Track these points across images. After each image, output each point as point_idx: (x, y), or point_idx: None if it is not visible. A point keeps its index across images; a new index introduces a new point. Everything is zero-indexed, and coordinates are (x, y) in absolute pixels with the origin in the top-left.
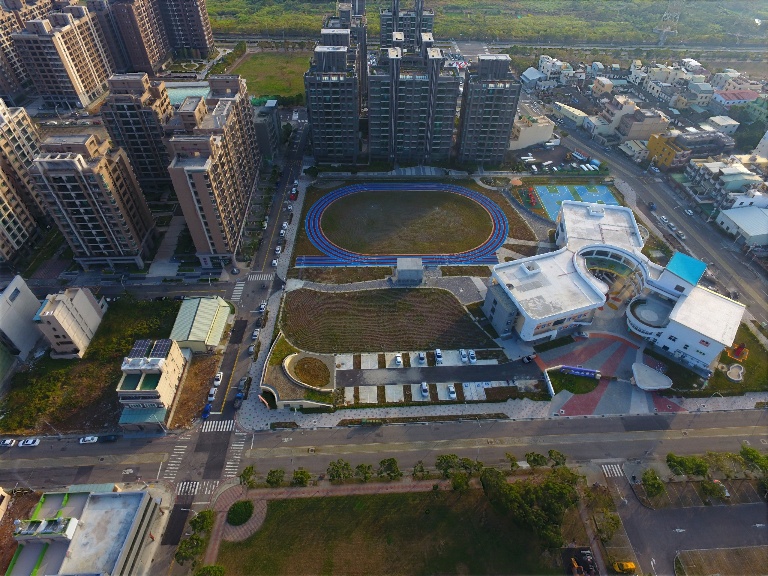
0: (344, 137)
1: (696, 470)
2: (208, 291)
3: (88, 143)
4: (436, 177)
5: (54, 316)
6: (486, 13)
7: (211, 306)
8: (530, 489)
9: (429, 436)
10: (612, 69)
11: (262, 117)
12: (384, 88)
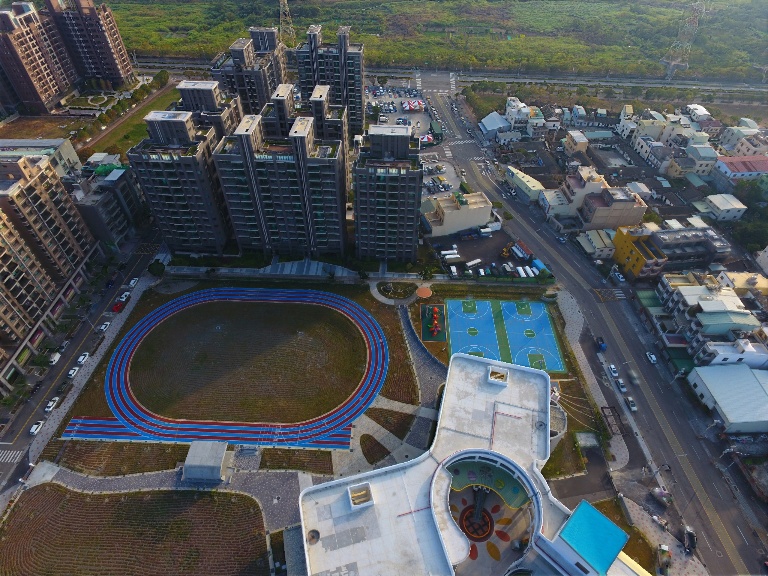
0: (198, 225)
1: None
2: None
3: None
4: (320, 279)
5: None
6: (472, 32)
7: None
8: None
9: None
10: (597, 115)
11: (98, 194)
12: (237, 170)
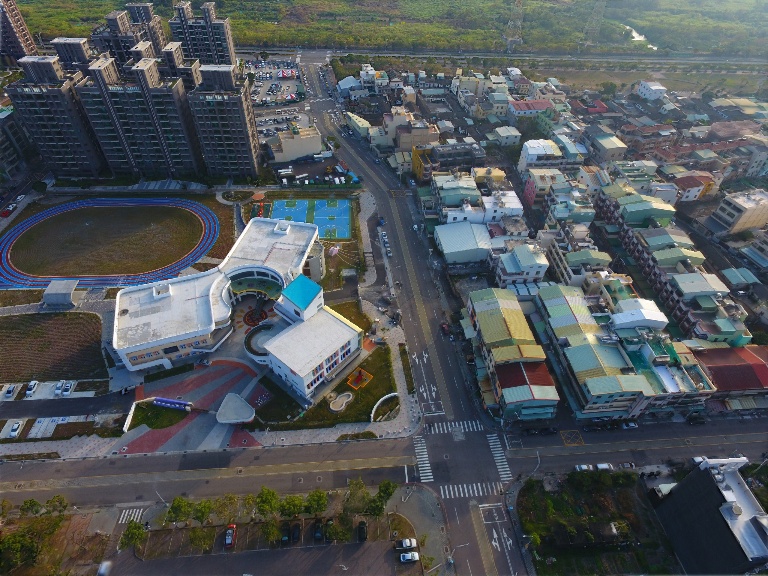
0: (73, 150)
1: (196, 516)
2: None
3: None
4: (177, 191)
5: None
6: (360, 20)
7: None
8: None
9: None
10: (437, 78)
11: None
12: (96, 100)
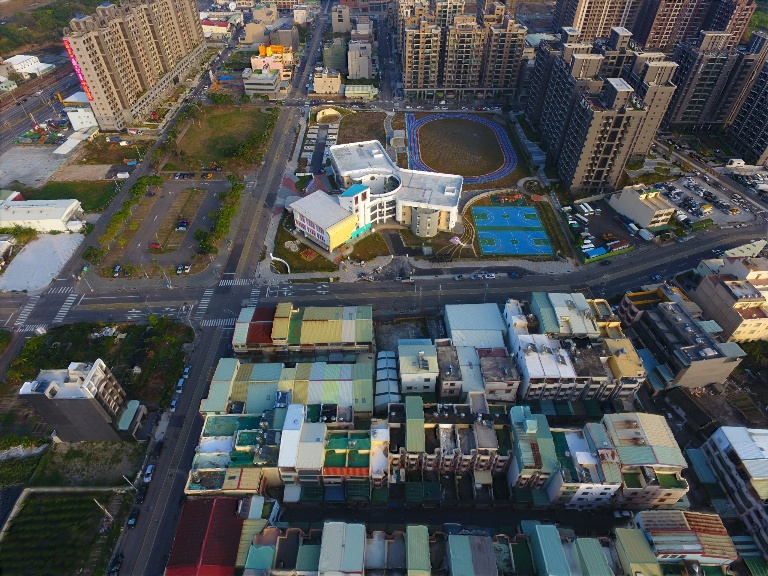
0: None
1: None
2: (386, 95)
3: (417, 8)
4: None
5: (348, 53)
6: None
7: (367, 89)
8: None
9: None
10: None
11: None
12: None
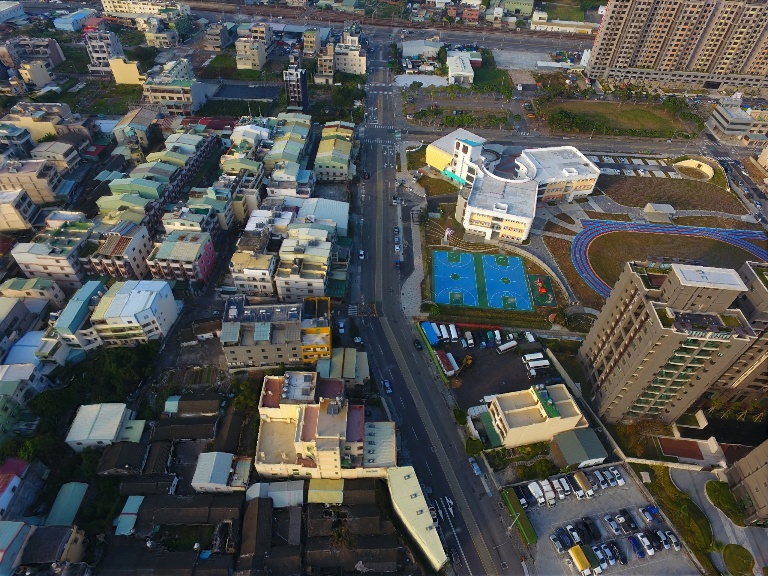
0: None
1: None
2: None
3: None
4: None
5: None
6: None
7: None
8: (572, 118)
9: (613, 148)
10: None
11: None
12: None
